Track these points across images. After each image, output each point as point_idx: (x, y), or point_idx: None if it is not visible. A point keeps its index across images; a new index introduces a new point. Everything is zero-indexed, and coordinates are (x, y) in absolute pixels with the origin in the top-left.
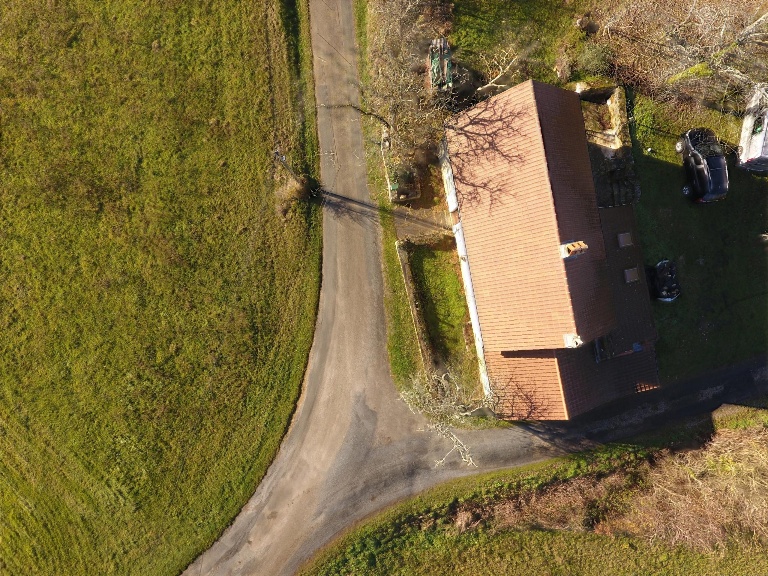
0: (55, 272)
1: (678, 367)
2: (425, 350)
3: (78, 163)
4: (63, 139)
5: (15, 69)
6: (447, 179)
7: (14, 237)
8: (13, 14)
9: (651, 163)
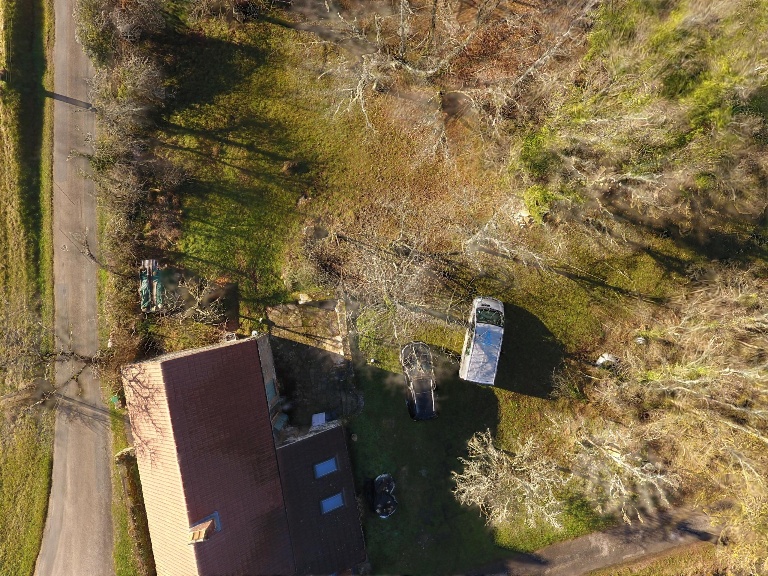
0: None
1: None
2: None
3: None
4: None
5: None
6: None
7: None
8: None
9: (375, 373)
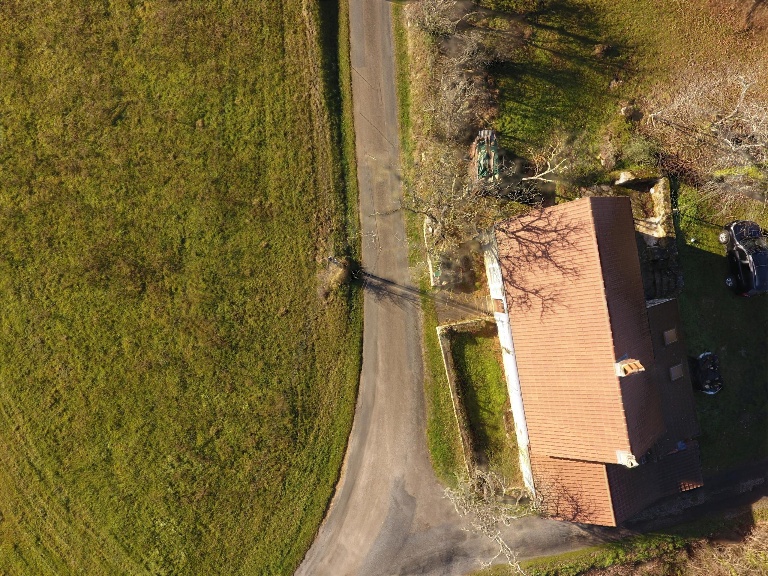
0: (97, 352)
1: (719, 459)
2: (467, 440)
3: (121, 243)
4: (106, 218)
5: (60, 147)
6: (491, 268)
7: (57, 317)
8: (58, 91)
9: (694, 253)
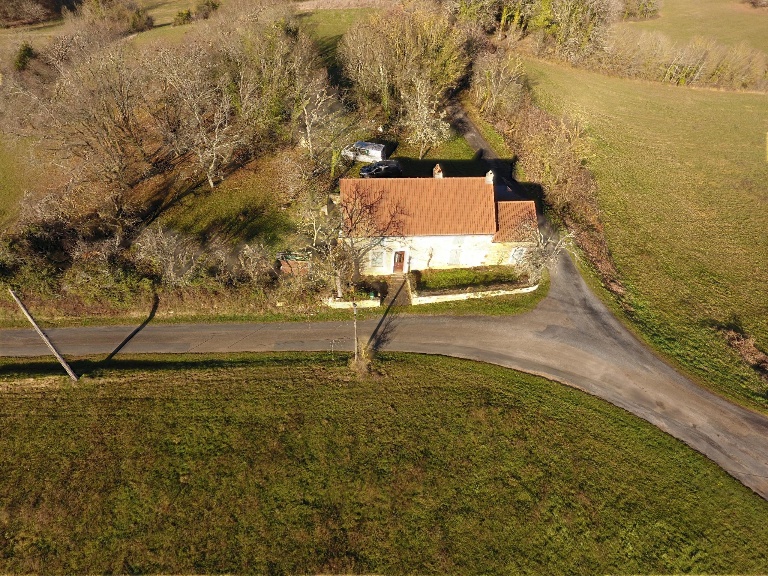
0: None
1: None
2: (495, 285)
3: None
4: None
5: None
6: (372, 265)
7: None
8: None
9: None
